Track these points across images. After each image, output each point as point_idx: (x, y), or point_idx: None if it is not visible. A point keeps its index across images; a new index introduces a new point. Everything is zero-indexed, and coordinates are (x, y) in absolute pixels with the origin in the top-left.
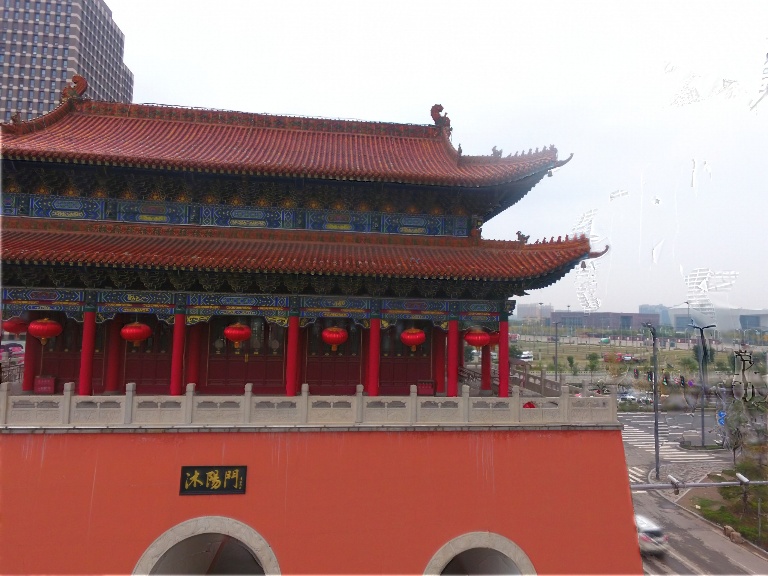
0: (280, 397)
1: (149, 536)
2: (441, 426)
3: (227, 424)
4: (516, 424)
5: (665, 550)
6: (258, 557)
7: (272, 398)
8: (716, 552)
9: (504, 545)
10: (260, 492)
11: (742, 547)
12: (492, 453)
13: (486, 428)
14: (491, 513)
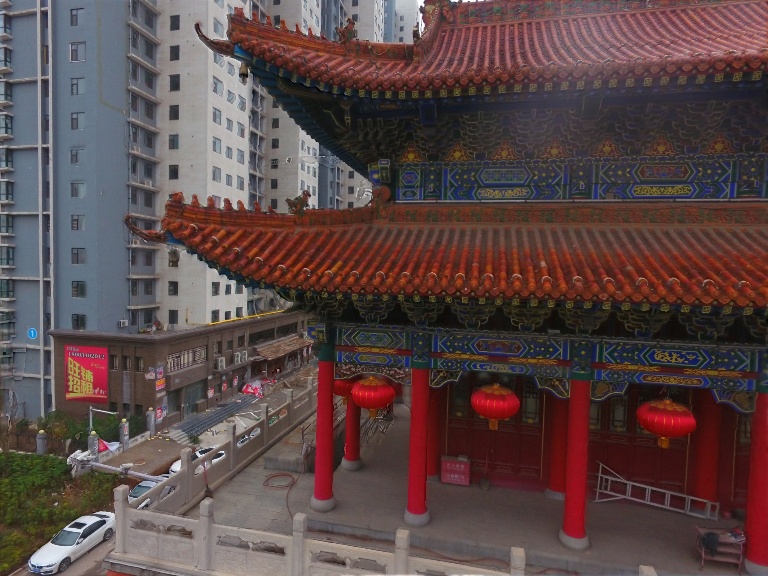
0: None
1: None
2: None
3: None
4: None
5: None
6: None
7: None
8: None
9: None
10: None
11: None
12: None
13: None
14: None
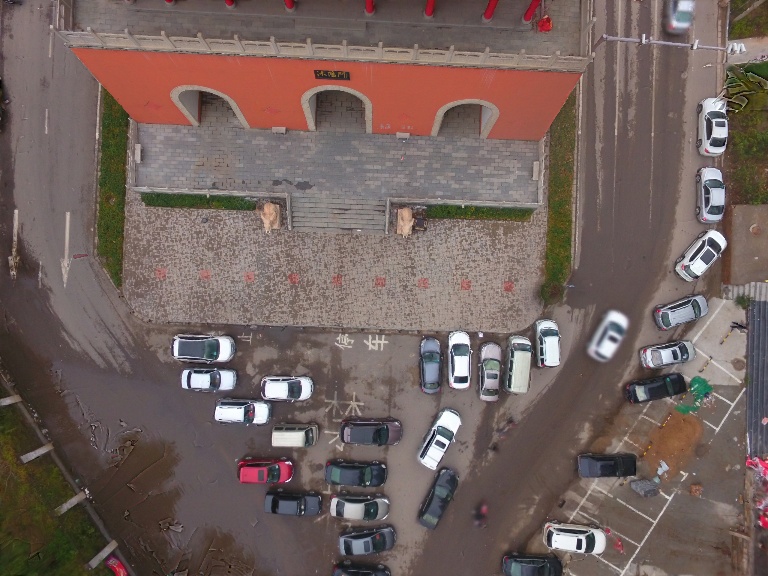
0: (365, 47)
1: (305, 88)
2: (465, 66)
3: (335, 58)
4: (514, 67)
5: (654, 8)
6: (359, 98)
7: (360, 48)
8: (691, 16)
9: (486, 103)
10: (358, 80)
11: (718, 12)
12: (493, 76)
13: (493, 68)
14: (484, 94)
